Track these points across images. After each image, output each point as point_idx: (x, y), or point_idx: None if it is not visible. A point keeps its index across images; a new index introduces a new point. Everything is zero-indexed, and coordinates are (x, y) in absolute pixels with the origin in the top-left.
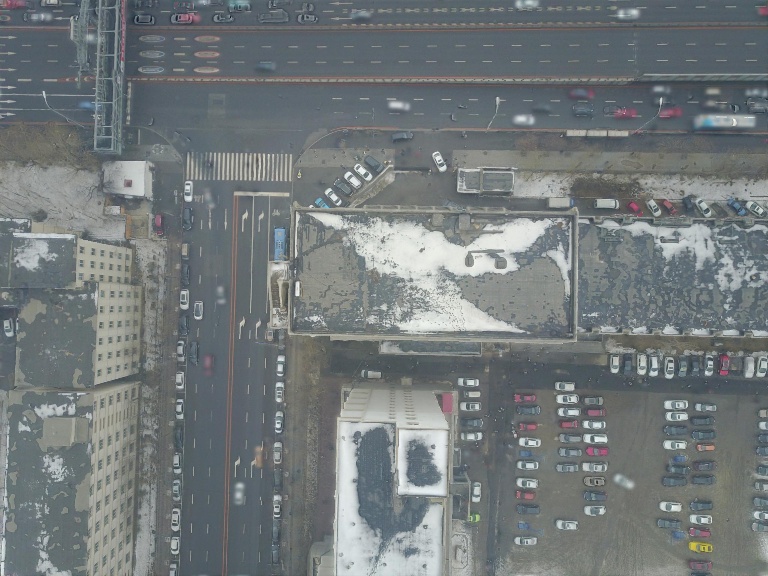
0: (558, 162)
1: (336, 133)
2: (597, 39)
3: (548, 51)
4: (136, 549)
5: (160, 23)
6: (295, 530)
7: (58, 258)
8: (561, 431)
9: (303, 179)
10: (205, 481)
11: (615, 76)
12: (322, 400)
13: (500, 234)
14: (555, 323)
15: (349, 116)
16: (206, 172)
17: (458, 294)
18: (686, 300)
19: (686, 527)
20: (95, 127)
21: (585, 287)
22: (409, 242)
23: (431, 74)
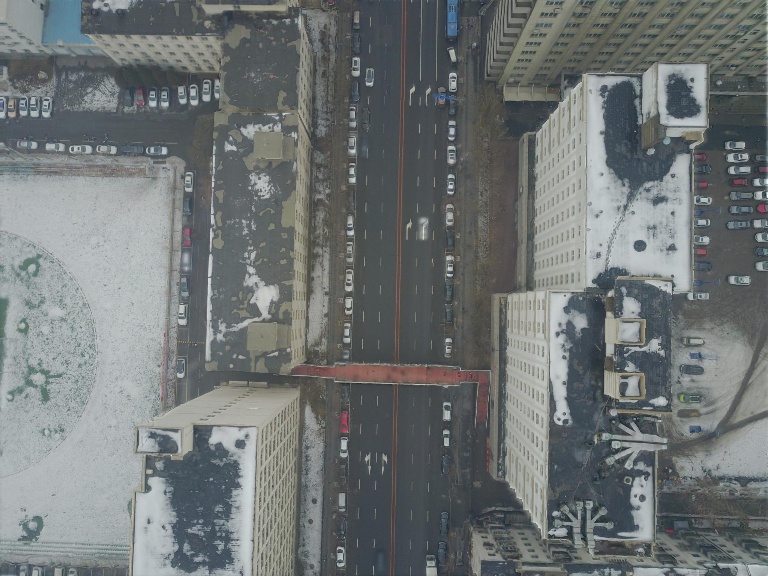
0: None
1: None
2: None
3: None
4: (309, 310)
5: None
6: (467, 290)
7: None
8: (731, 190)
9: None
10: (377, 244)
11: None
12: (504, 148)
13: None
14: None
15: None
16: None
17: None
18: None
19: None
20: None
21: None
22: None
23: None
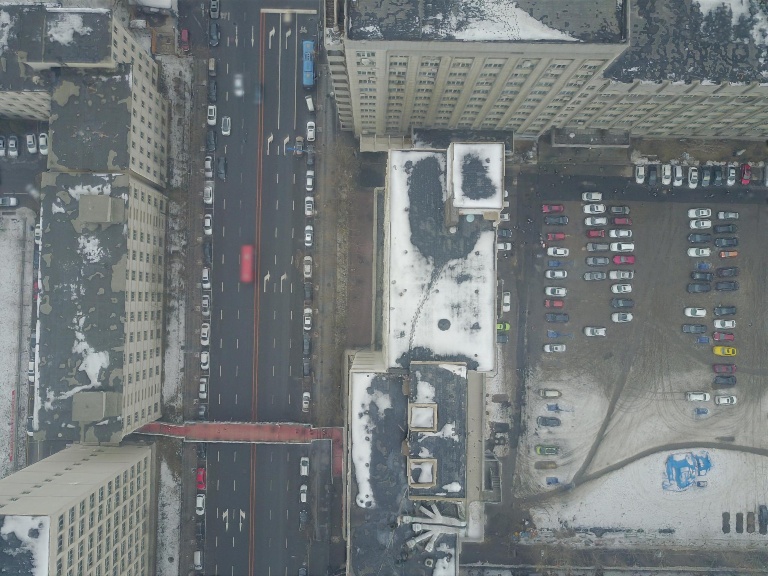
0: None
1: None
2: None
3: None
4: (165, 365)
5: None
6: (326, 343)
7: (93, 32)
8: (588, 241)
9: None
10: (234, 296)
11: None
12: (355, 202)
13: None
14: (608, 31)
15: None
16: None
17: (513, 3)
18: (723, 54)
19: (710, 332)
20: None
21: None
22: None
23: None
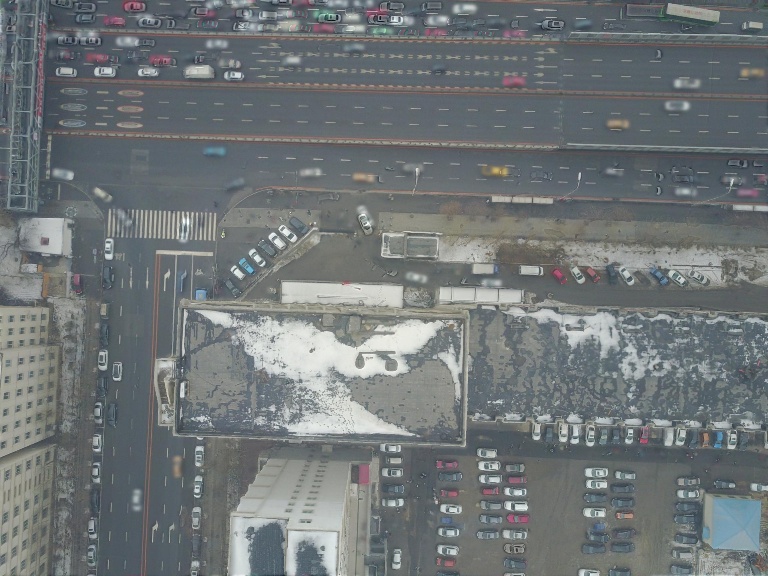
0: (484, 227)
1: (262, 192)
2: (524, 105)
3: (475, 116)
4: None
5: (83, 76)
6: None
7: None
8: (482, 498)
9: (227, 239)
10: (121, 546)
11: (541, 143)
12: (239, 469)
13: (391, 335)
14: (445, 426)
15: (275, 175)
16: (128, 229)
17: (348, 396)
18: (590, 388)
19: None
20: (9, 185)
21: (490, 374)
22: (299, 342)
23: (358, 136)
